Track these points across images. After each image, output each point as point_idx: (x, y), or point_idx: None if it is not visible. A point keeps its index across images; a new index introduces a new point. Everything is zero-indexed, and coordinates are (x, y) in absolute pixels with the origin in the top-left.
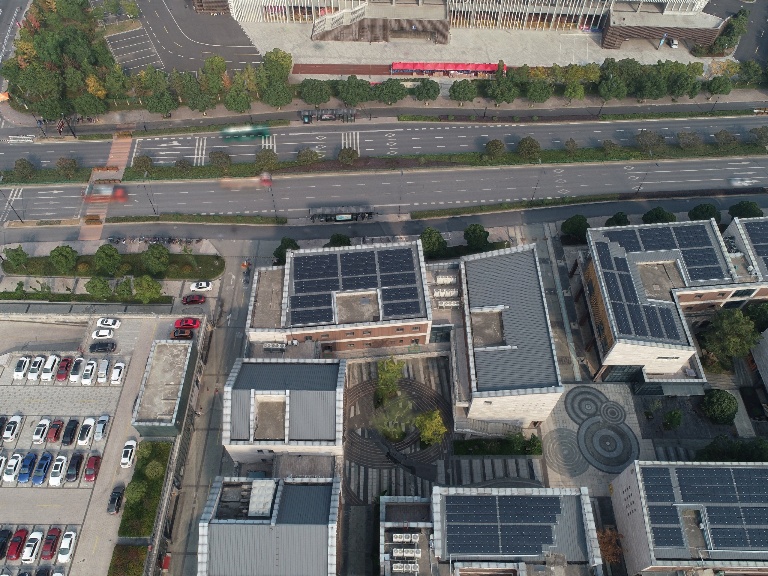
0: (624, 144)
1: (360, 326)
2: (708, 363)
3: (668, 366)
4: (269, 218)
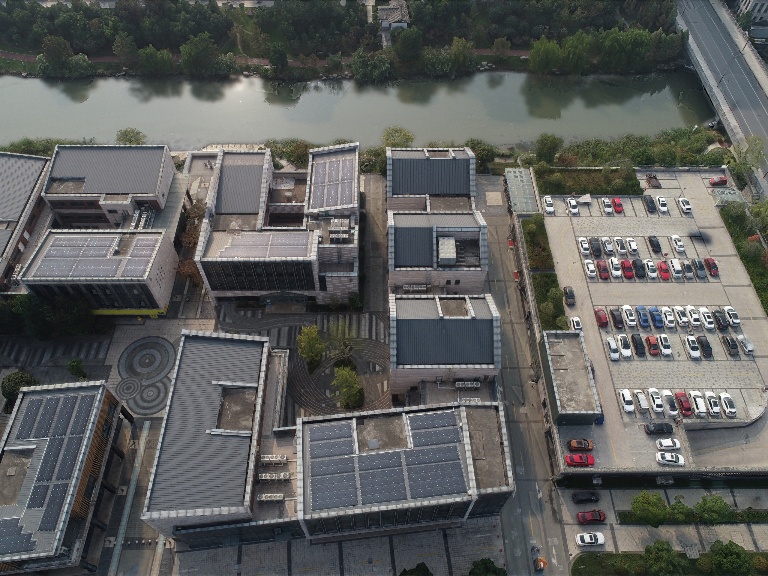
0: None
1: (378, 411)
2: None
3: None
4: None
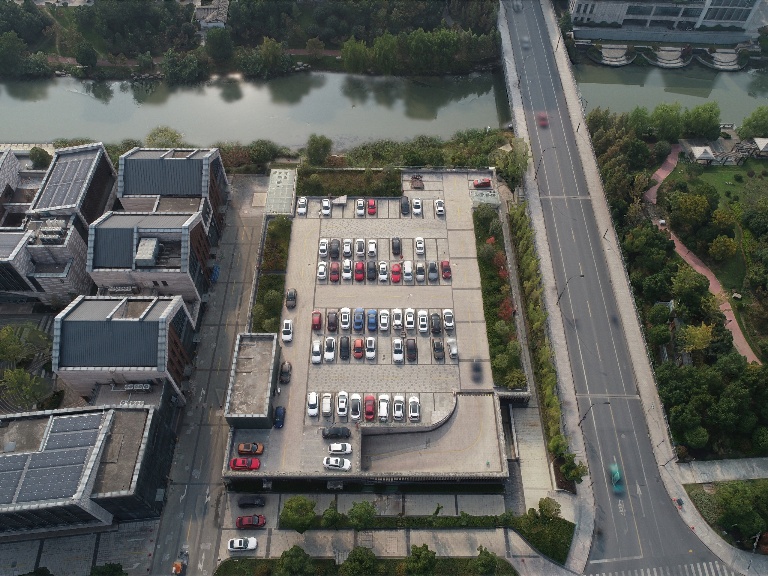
0: None
1: (26, 413)
2: None
3: None
4: None
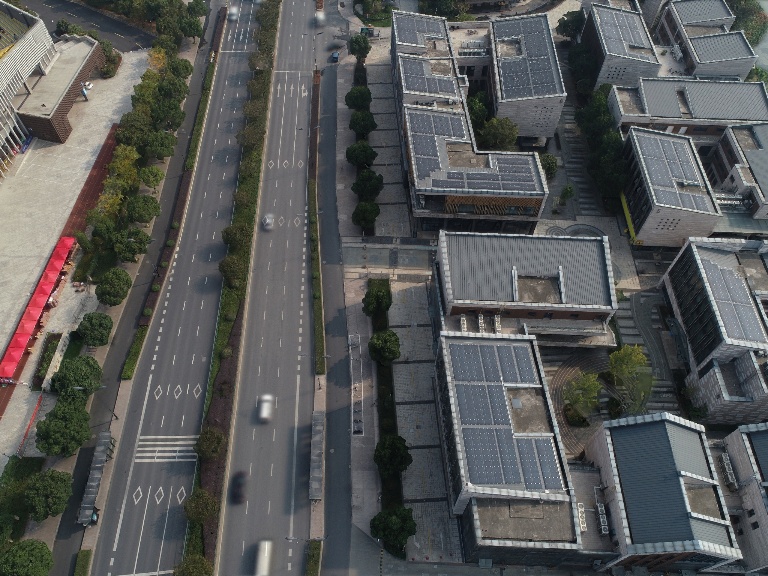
0: (235, 160)
1: None
2: None
3: None
4: (310, 569)
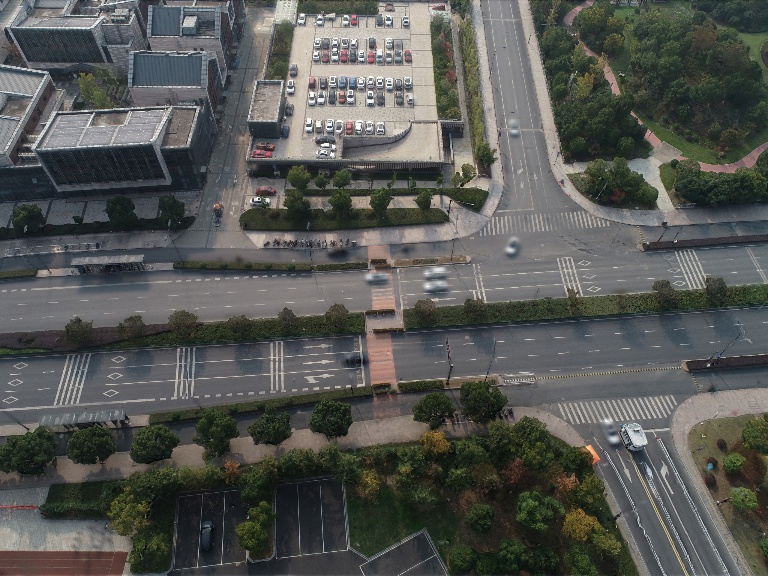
0: None
1: (112, 109)
2: None
3: None
4: (192, 265)
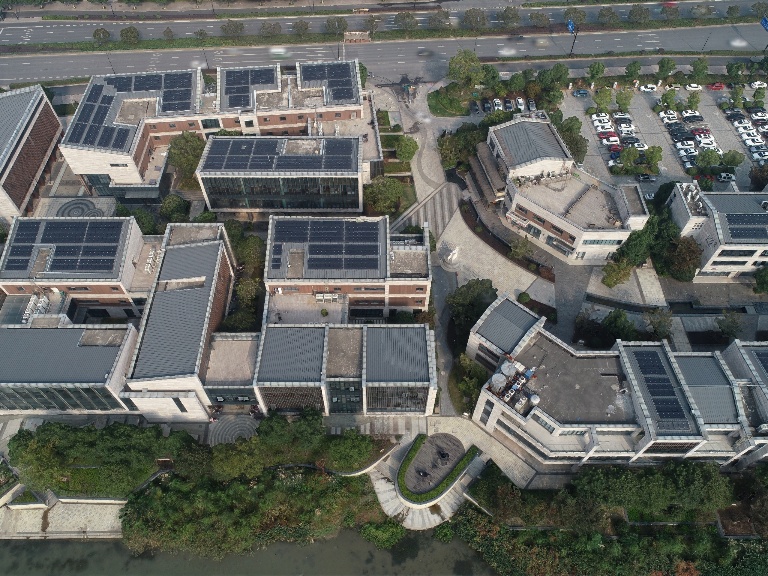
0: (226, 35)
1: None
2: (187, 182)
3: (128, 175)
4: None
